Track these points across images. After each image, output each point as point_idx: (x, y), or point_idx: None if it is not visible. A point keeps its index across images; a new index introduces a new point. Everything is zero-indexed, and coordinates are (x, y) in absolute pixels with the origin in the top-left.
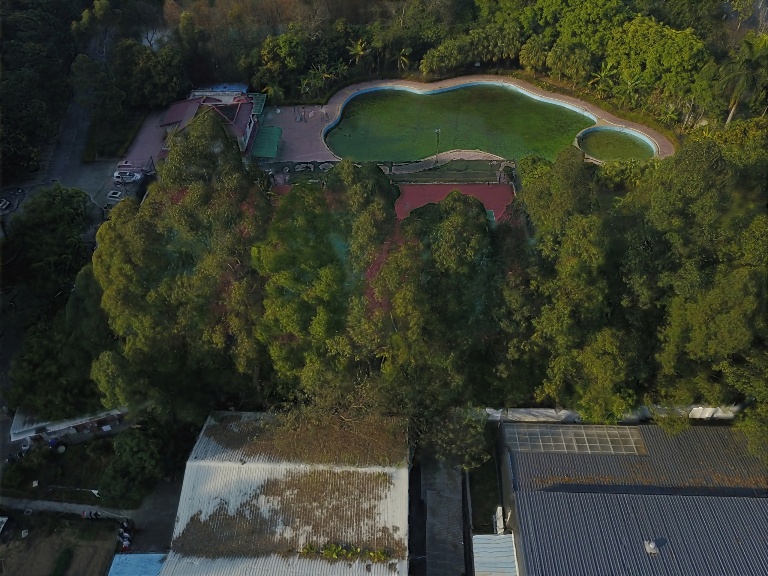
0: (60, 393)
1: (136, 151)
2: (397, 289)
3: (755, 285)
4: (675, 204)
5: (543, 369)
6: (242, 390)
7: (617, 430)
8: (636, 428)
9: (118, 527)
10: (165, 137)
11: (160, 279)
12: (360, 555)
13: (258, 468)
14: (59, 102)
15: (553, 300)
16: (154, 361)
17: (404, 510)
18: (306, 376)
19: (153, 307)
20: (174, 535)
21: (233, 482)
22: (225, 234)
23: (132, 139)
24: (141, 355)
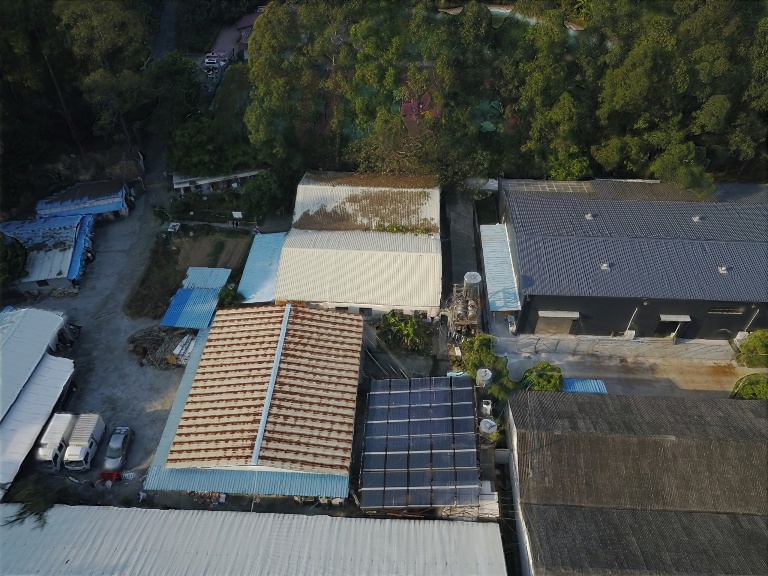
0: (207, 156)
1: (217, 49)
2: (438, 55)
3: (652, 53)
4: (605, 4)
5: (527, 134)
6: (329, 153)
7: (575, 183)
8: (588, 182)
9: (252, 229)
10: (240, 39)
11: (291, 53)
12: (410, 230)
13: (344, 189)
14: (156, 11)
15: (533, 73)
16: (280, 116)
17: (437, 210)
18: (380, 113)
19: (285, 73)
20: (293, 221)
21: (328, 196)
22: (342, 6)
23: (213, 41)
24: (273, 111)
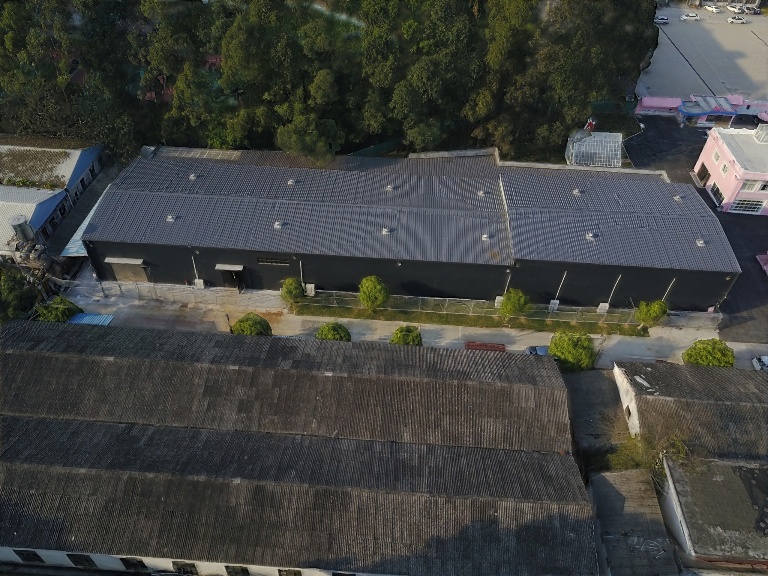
0: None
1: None
2: (53, 21)
3: (248, 26)
4: None
5: None
6: None
7: (229, 151)
8: (241, 151)
9: None
10: None
11: None
12: (37, 186)
13: None
14: None
15: None
16: None
17: (71, 169)
18: None
19: None
20: None
21: None
22: None
23: None
24: None
